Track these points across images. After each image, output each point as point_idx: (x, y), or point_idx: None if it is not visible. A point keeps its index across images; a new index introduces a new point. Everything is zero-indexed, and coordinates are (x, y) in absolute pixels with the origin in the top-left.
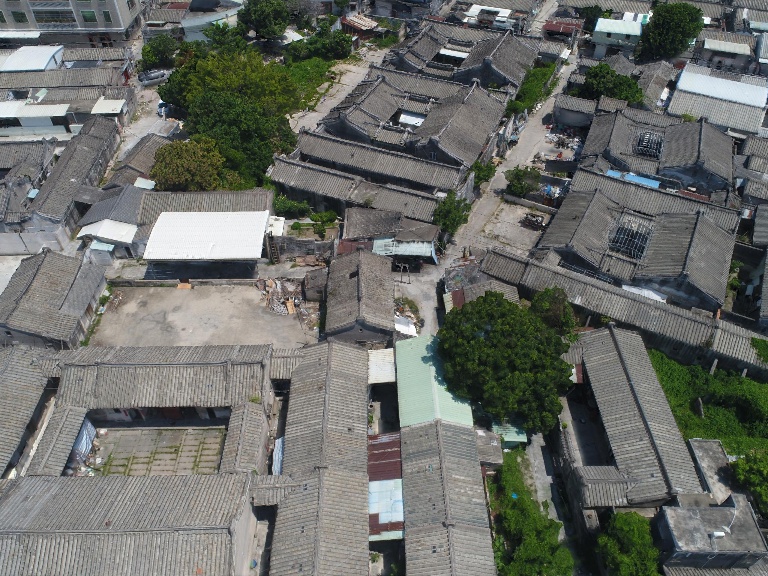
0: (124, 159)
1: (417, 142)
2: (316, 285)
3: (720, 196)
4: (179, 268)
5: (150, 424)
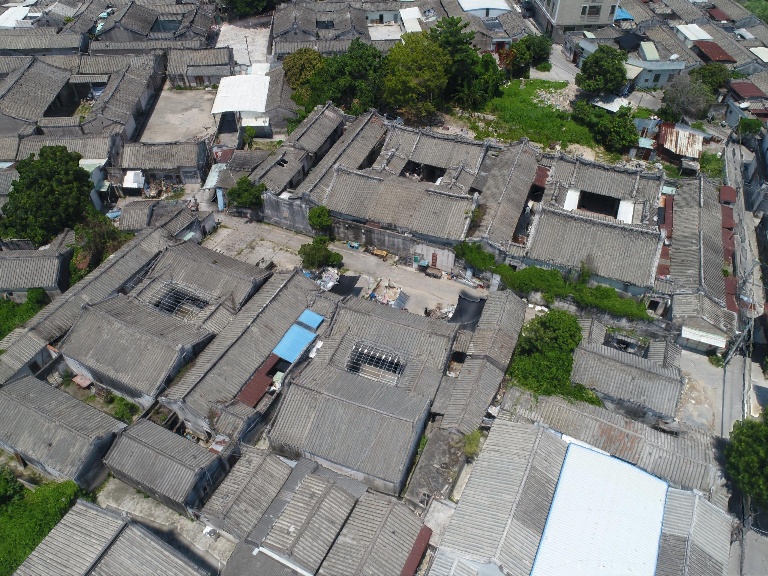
0: None
1: None
2: None
3: (242, 410)
4: None
5: None
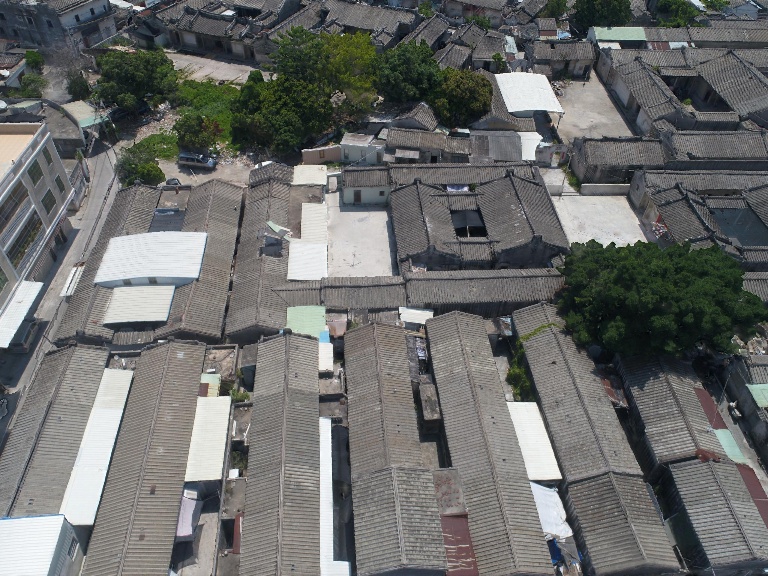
0: (427, 145)
1: (397, 27)
2: (549, 70)
3: None
4: None
5: None
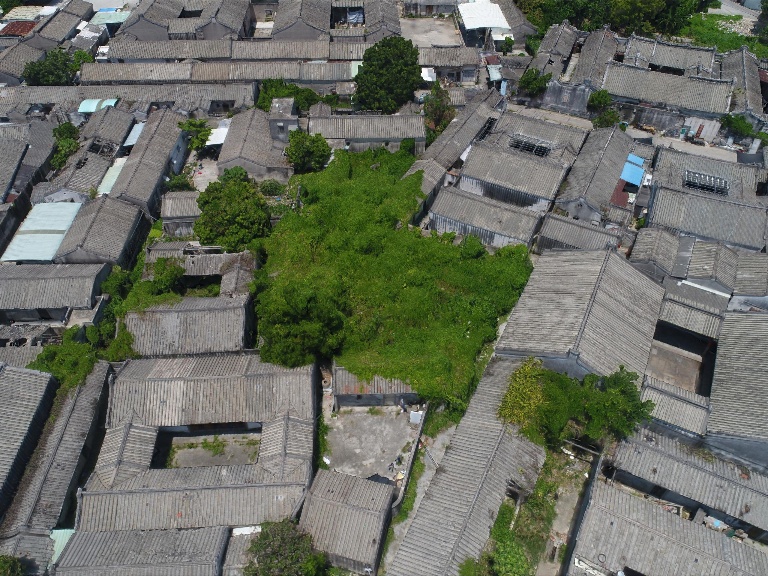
0: None
1: None
2: None
3: None
4: (472, 30)
5: None
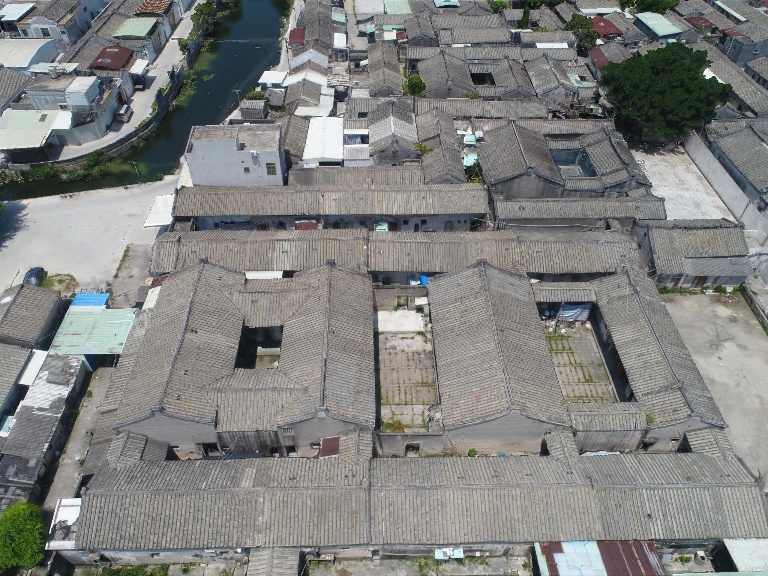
0: None
1: None
2: None
3: None
4: None
5: (606, 356)
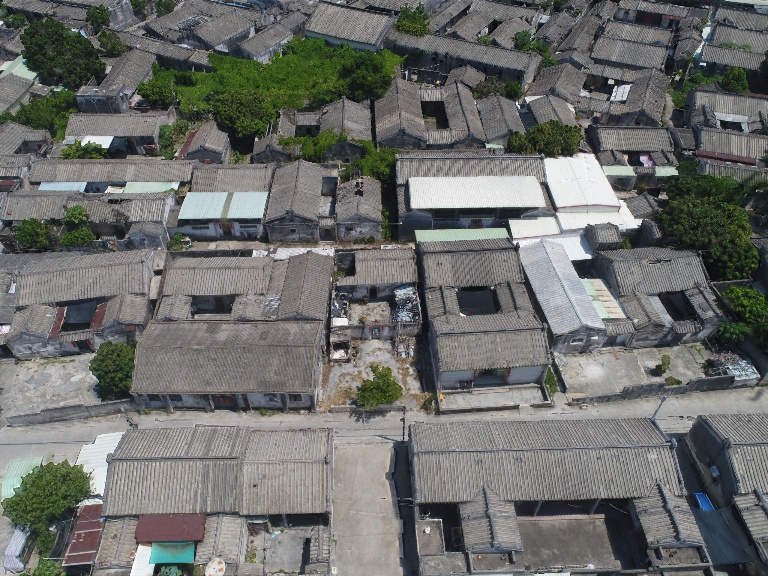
0: None
1: None
2: None
3: None
4: None
5: None
